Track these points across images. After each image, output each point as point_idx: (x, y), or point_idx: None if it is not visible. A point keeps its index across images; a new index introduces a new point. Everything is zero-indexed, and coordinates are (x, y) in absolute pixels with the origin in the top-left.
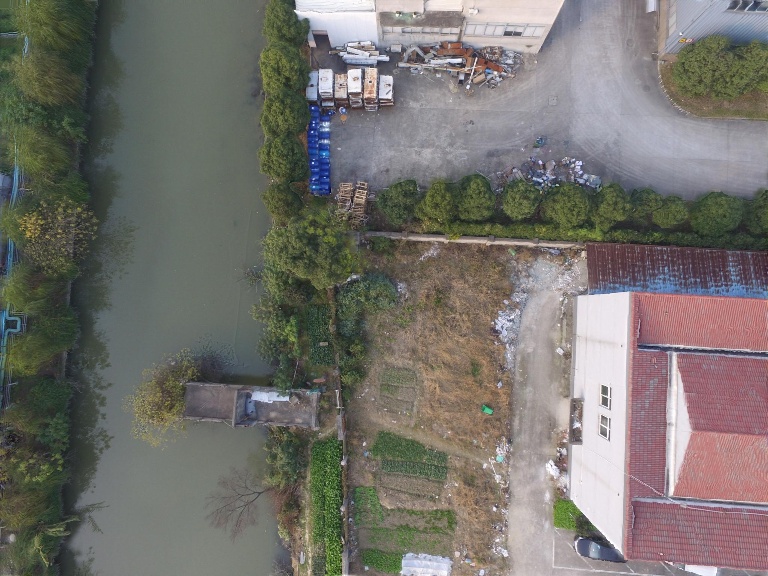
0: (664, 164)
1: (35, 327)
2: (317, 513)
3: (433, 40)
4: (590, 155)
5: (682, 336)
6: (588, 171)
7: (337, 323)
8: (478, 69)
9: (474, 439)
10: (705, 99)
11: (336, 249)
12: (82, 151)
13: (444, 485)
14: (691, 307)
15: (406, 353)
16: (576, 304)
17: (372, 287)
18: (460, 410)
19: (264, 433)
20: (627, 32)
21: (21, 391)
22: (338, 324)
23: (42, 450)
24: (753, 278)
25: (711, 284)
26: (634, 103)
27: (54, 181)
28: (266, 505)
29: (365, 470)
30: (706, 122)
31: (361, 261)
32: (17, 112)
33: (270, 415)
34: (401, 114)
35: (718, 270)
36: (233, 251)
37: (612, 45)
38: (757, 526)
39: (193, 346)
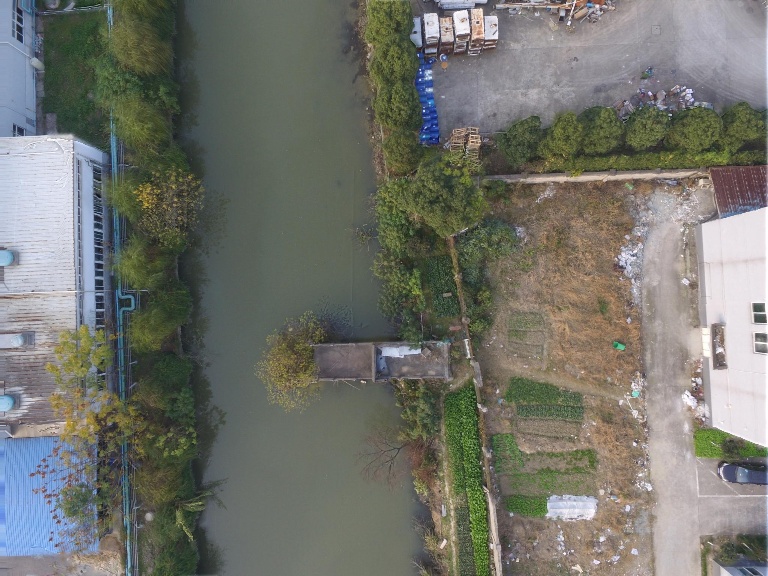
0: None
1: (153, 302)
2: (456, 464)
3: None
4: (699, 82)
5: None
6: (699, 98)
7: (462, 272)
8: (579, 4)
9: (608, 376)
10: None
11: (469, 191)
12: (175, 123)
13: (582, 425)
14: None
15: (531, 297)
16: (700, 232)
17: (493, 233)
18: (592, 349)
19: (390, 391)
20: None
21: (142, 369)
22: (463, 272)
23: (174, 425)
24: None
25: None
26: (739, 26)
27: (159, 152)
28: (404, 461)
29: (501, 417)
30: None
31: None
32: (114, 84)
33: (402, 370)
34: (503, 56)
35: None
36: (340, 212)
37: None
38: None
39: (313, 309)
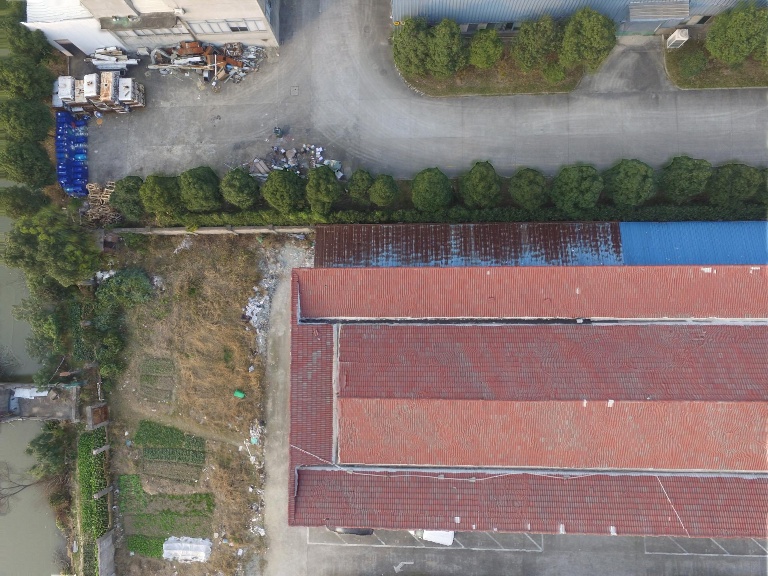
0: (401, 145)
1: None
2: (85, 503)
3: (172, 41)
4: (331, 141)
5: (344, 308)
6: (329, 156)
7: (92, 318)
8: (220, 66)
9: (228, 423)
10: (433, 79)
11: (60, 247)
12: None
13: (202, 469)
14: (347, 279)
15: (163, 344)
16: None
17: (124, 282)
18: (214, 395)
19: None
20: (364, 19)
21: None
22: (92, 319)
23: None
24: (473, 249)
25: (431, 258)
26: (372, 88)
27: None
28: (38, 497)
29: (128, 459)
30: (441, 101)
31: (120, 258)
32: None
33: (33, 410)
34: (153, 114)
35: (440, 244)
36: None
37: (350, 33)
38: (418, 487)
39: None
